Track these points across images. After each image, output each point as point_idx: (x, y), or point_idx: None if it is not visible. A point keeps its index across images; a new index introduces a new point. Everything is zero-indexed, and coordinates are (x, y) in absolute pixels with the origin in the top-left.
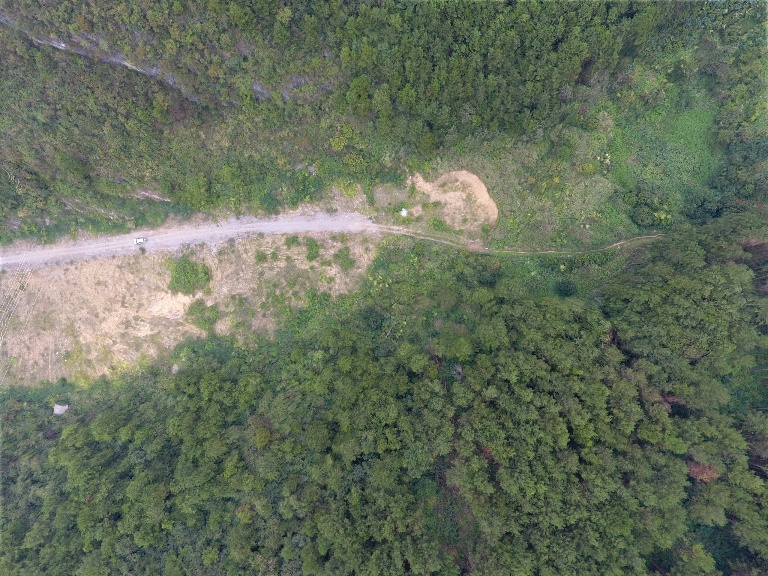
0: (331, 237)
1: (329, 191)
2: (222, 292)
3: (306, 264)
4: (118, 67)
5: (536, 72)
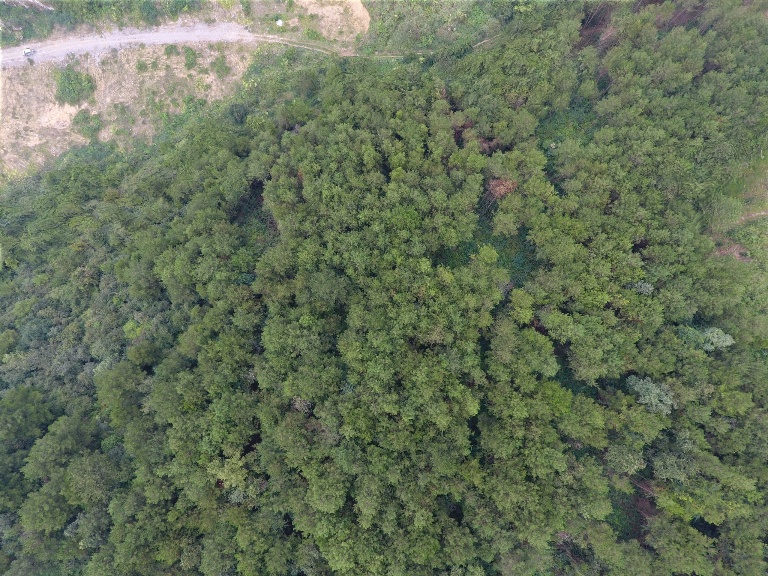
0: (208, 46)
1: (208, 2)
2: (106, 102)
3: (184, 73)
4: None
5: None
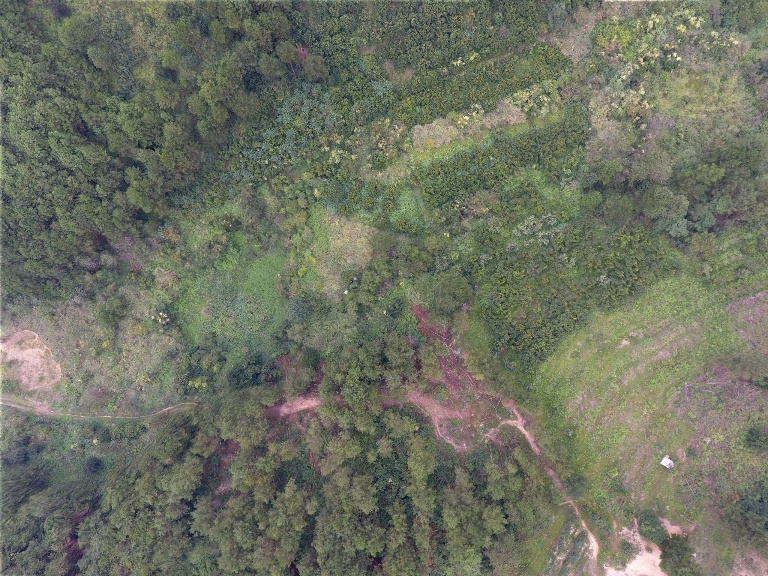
0: None
1: None
2: None
3: None
4: None
5: (30, 252)
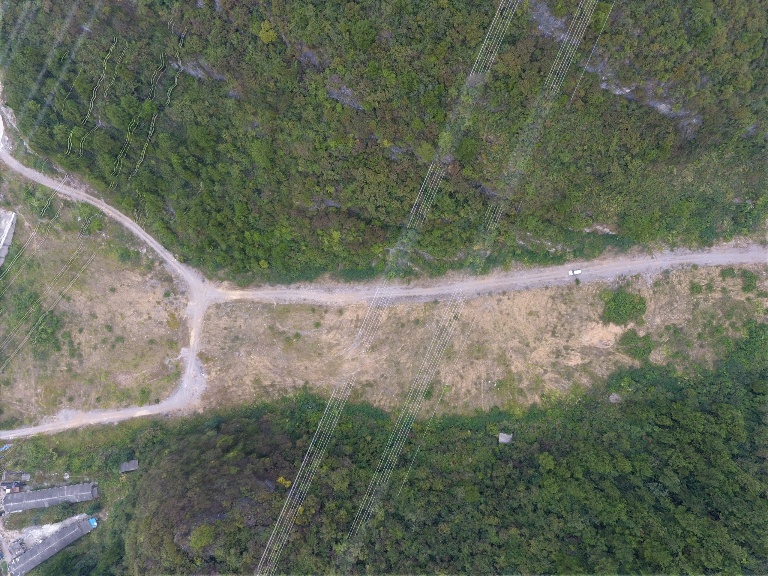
0: (767, 269)
1: None
2: (655, 322)
3: (742, 295)
4: (663, 111)
5: None
